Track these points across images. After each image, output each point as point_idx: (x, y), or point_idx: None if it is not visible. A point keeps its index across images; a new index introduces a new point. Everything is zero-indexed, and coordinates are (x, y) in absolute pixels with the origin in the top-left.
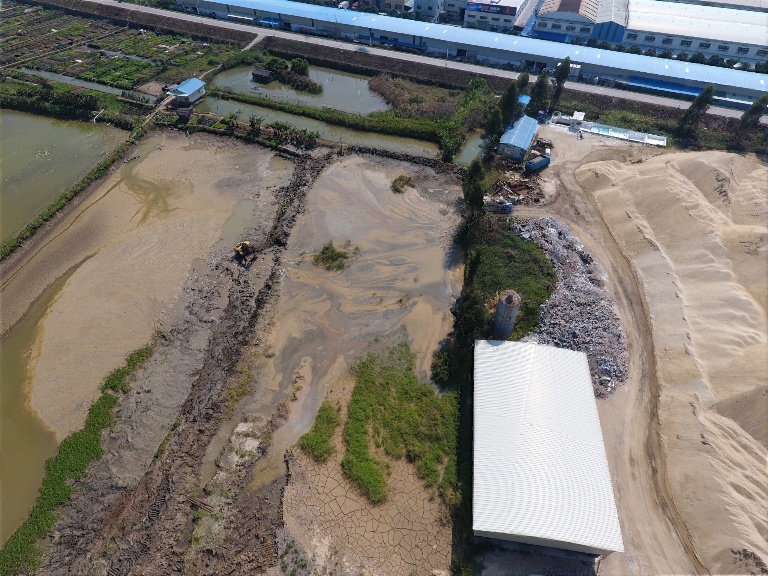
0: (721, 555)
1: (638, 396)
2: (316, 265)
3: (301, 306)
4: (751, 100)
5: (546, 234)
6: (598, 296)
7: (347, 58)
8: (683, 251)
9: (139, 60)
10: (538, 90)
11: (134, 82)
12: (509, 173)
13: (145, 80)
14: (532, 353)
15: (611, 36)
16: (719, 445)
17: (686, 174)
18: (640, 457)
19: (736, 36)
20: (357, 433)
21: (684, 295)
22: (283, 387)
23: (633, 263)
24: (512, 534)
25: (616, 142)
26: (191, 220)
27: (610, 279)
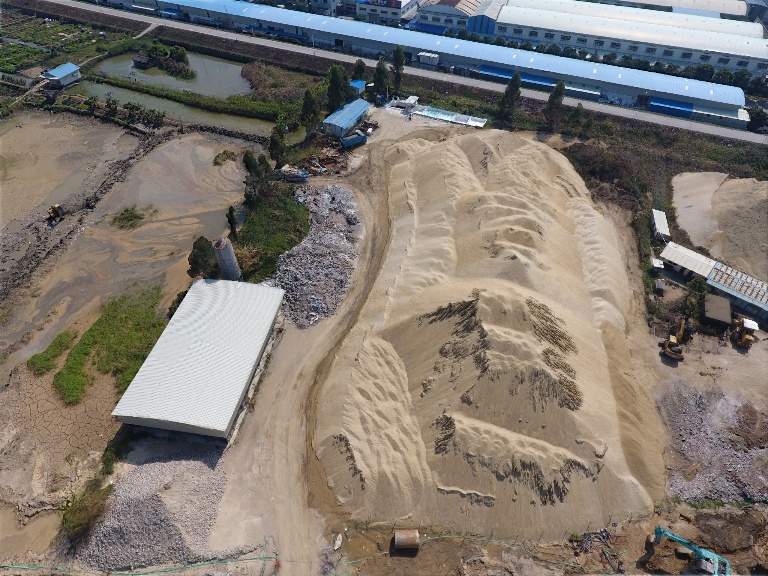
0: (326, 440)
1: (335, 328)
2: (112, 224)
3: (82, 257)
4: (584, 88)
5: (316, 198)
6: (338, 249)
7: (228, 47)
8: (428, 213)
9: (33, 47)
10: (378, 76)
11: (18, 66)
12: (326, 149)
13: (30, 65)
14: (236, 289)
15: (485, 29)
16: (365, 361)
17: (464, 149)
18: (309, 373)
19: (593, 29)
20: (78, 354)
21: (412, 248)
22: (36, 320)
23: (393, 224)
24: (138, 417)
25: (440, 123)
26: (23, 188)
27: (365, 237)
